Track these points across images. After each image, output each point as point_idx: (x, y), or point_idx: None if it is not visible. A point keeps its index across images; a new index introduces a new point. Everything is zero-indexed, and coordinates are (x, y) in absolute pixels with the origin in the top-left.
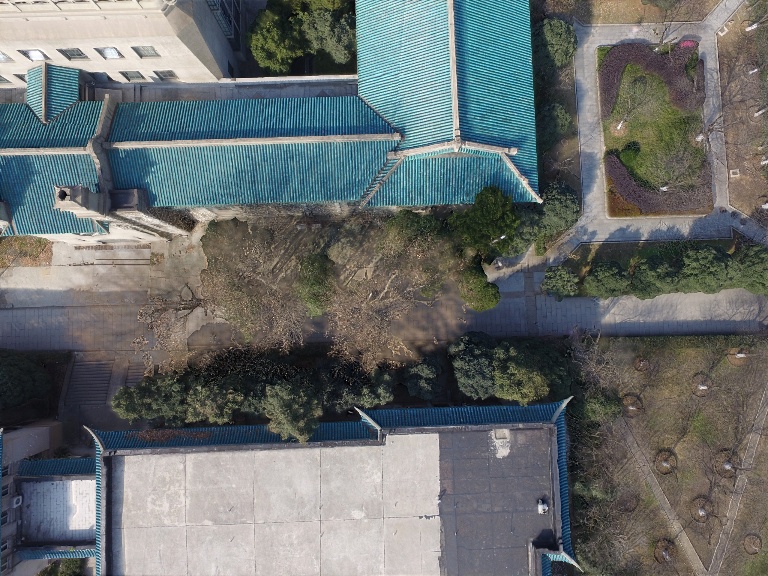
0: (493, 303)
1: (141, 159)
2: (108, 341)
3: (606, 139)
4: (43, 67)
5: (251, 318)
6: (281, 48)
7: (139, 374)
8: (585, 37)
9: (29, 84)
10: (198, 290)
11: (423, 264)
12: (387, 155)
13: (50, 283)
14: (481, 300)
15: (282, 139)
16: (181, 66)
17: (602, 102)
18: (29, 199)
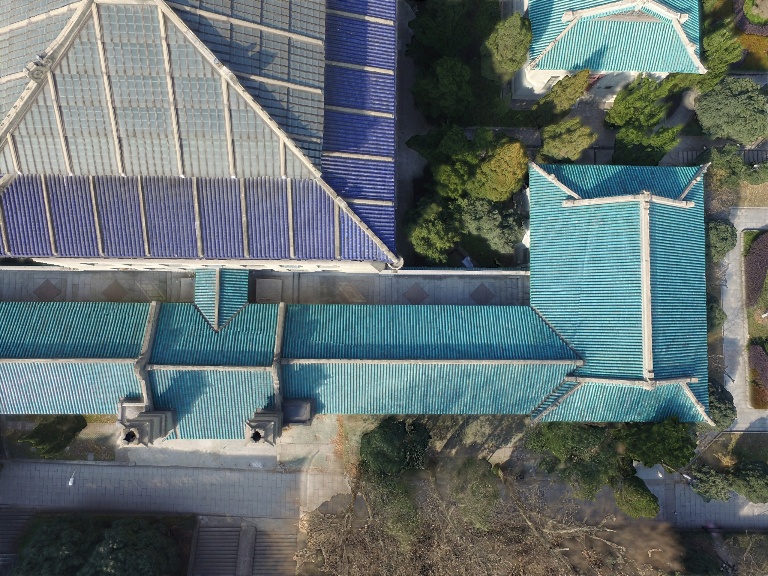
0: (653, 516)
1: (315, 372)
2: (234, 506)
3: (750, 326)
4: (217, 273)
5: (415, 532)
6: (445, 242)
7: (267, 545)
8: (731, 219)
9: (198, 284)
10: (329, 459)
11: (587, 477)
12: (566, 379)
13: (175, 443)
14: (640, 511)
15: (464, 362)
16: (353, 269)
17: (749, 290)
18: (198, 408)
